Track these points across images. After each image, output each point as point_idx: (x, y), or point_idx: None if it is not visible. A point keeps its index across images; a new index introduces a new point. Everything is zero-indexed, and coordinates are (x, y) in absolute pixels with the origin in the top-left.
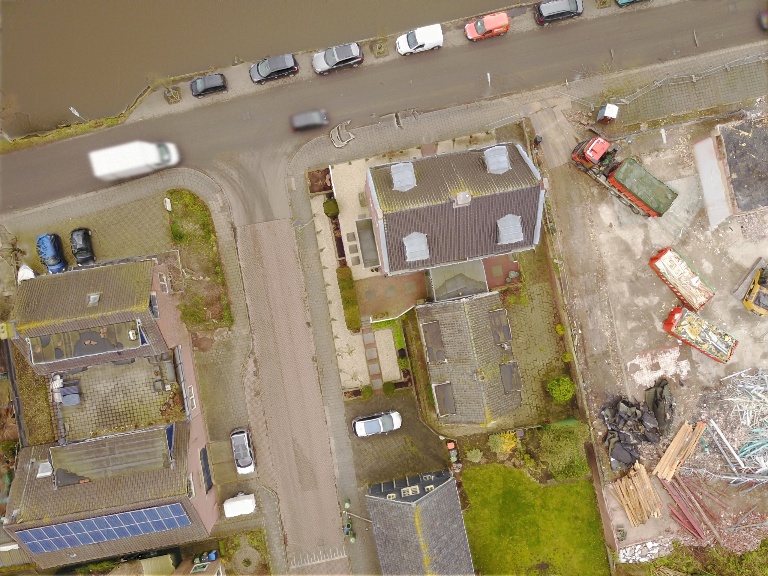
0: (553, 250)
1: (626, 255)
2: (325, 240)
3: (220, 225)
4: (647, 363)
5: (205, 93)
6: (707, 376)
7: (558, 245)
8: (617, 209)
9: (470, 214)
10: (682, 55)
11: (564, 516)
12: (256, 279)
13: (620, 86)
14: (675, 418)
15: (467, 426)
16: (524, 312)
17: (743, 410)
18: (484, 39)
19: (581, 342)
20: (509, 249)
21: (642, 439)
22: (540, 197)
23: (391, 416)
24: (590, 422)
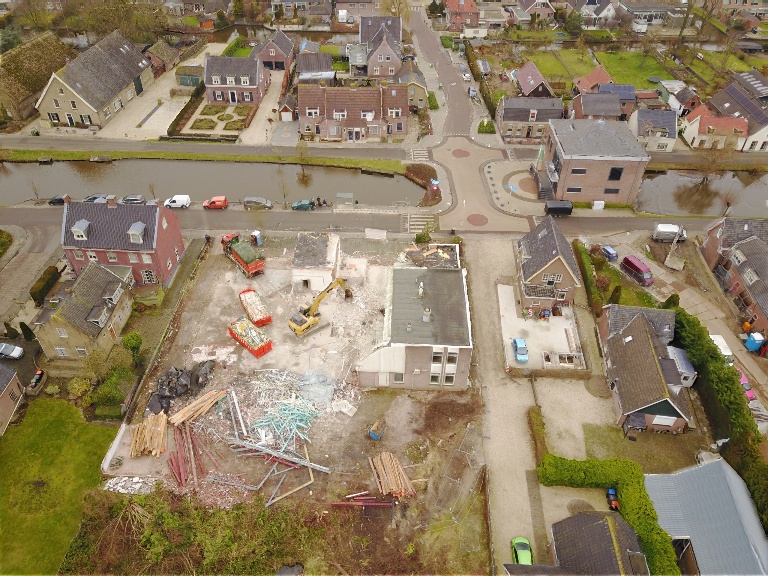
0: (185, 286)
1: (230, 296)
2: (61, 265)
3: (11, 250)
4: (208, 350)
5: (54, 202)
6: (246, 366)
7: (191, 285)
8: (237, 275)
9: (117, 215)
10: (319, 231)
11: (86, 449)
12: (6, 275)
13: (276, 235)
14: (208, 386)
15: (63, 371)
16: (151, 320)
17: (261, 391)
18: (212, 209)
19: (174, 336)
20: (139, 250)
21: (174, 393)
22: (157, 212)
23: (15, 347)
24: (148, 383)
